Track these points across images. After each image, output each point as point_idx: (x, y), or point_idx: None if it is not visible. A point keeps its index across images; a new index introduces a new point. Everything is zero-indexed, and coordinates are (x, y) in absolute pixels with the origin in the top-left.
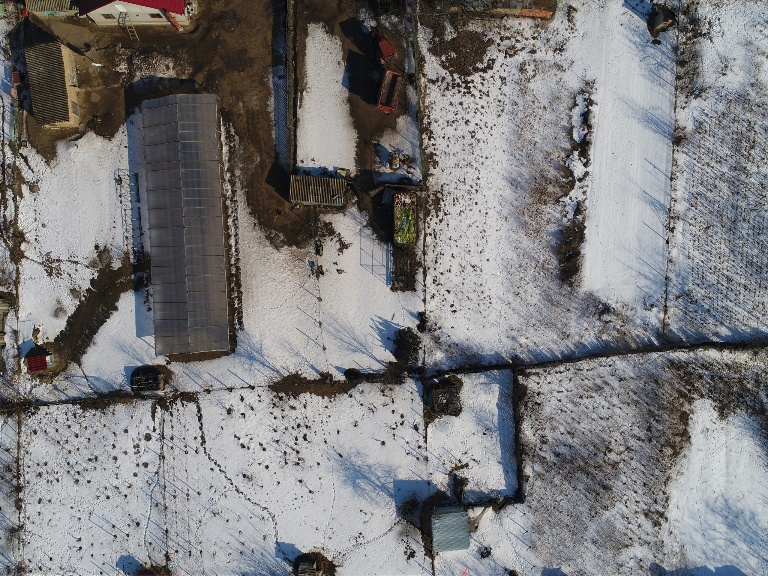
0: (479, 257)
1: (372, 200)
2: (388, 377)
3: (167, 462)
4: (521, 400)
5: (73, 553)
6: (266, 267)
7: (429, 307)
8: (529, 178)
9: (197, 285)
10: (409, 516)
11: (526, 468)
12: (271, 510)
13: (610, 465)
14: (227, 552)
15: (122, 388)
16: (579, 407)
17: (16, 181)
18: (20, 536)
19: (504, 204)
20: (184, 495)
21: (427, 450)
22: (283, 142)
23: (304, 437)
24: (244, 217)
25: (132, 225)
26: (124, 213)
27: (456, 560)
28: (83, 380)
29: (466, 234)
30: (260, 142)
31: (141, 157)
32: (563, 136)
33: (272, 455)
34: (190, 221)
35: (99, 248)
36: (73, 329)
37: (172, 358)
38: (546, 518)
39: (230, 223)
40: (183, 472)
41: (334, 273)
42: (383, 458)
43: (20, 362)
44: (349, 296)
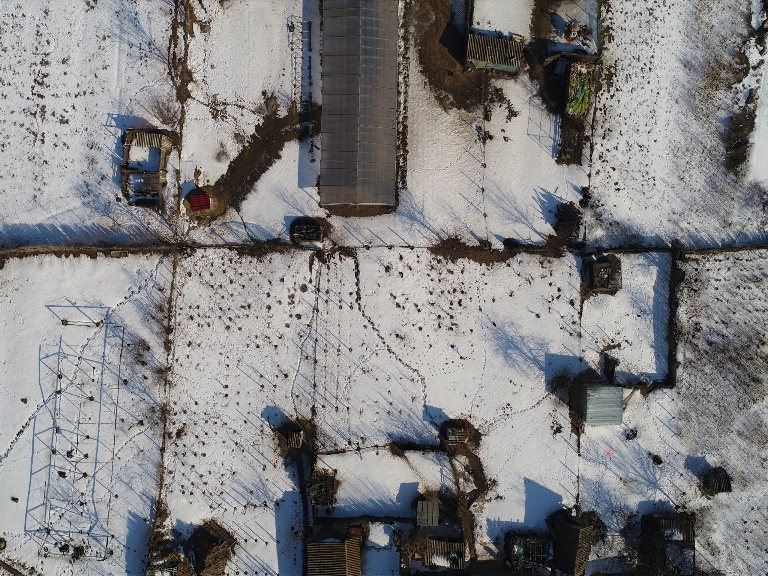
0: (647, 137)
1: (544, 70)
2: (548, 249)
3: (320, 315)
4: (678, 285)
5: (219, 399)
6: (433, 128)
7: (593, 183)
8: (703, 61)
9: (368, 136)
10: (558, 391)
11: (678, 354)
12: (421, 372)
13: (762, 358)
14: (374, 411)
15: (281, 237)
16: (735, 297)
17: (189, 18)
18: (167, 378)
19: (676, 86)
20: (335, 350)
21: (581, 326)
22: (460, 2)
23: (459, 302)
24: (415, 75)
25: (301, 74)
26: (294, 61)
27: (601, 440)
28: (241, 226)
29: (636, 112)
30: (437, 0)
31: (316, 5)
32: (741, 22)
33: (426, 317)
34: (366, 70)
35: (266, 94)
36: (234, 174)
37: (332, 211)
38: (694, 406)
39: (401, 80)
40: (336, 327)
41: (501, 140)
42: (536, 330)
43: (180, 202)
44: (514, 165)
